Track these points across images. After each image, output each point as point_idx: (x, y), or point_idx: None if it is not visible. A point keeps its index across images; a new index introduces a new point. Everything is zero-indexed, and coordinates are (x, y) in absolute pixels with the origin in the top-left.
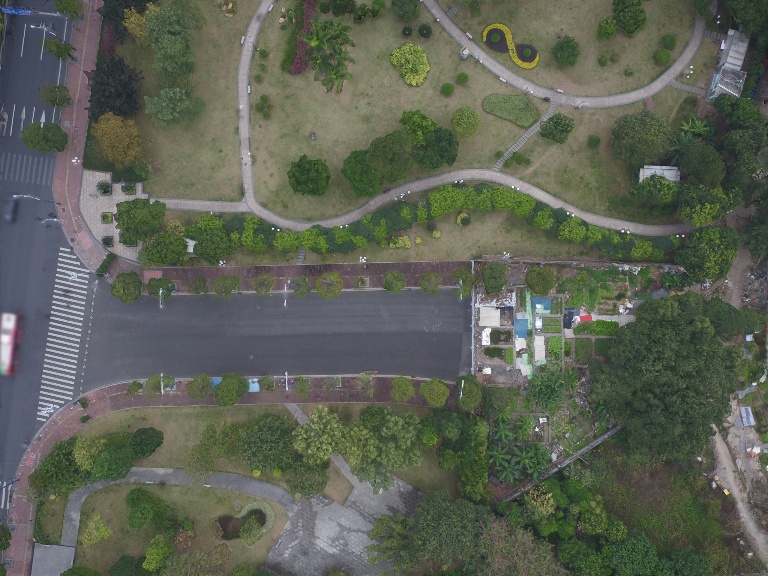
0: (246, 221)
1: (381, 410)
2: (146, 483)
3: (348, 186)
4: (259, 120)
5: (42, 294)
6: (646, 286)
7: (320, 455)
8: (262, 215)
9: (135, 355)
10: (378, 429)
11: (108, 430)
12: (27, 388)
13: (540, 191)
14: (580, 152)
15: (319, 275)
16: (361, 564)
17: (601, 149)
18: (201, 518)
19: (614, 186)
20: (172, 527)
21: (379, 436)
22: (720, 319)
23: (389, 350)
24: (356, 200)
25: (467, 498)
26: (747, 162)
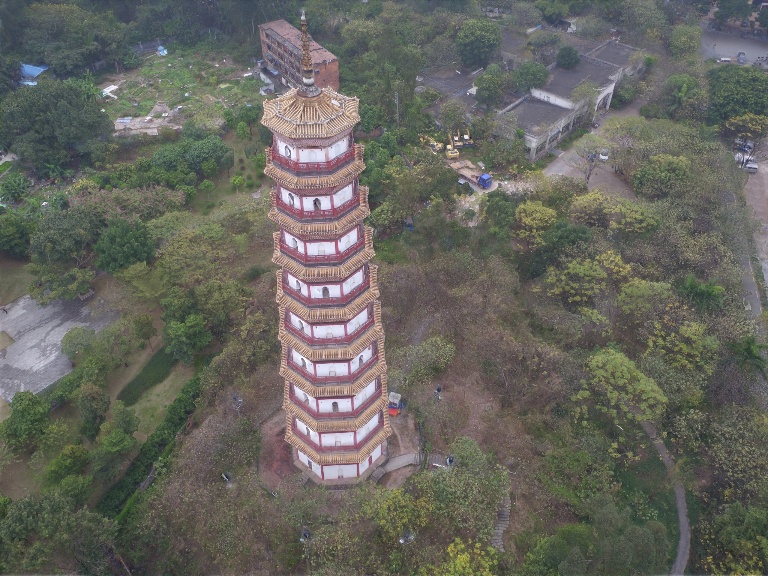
0: None
1: None
2: None
3: None
4: None
5: None
6: None
7: None
8: None
9: None
10: None
11: None
12: None
13: None
14: None
15: None
16: None
17: None
18: None
19: None
20: None
21: None
22: None
23: None
24: None
25: None
26: None
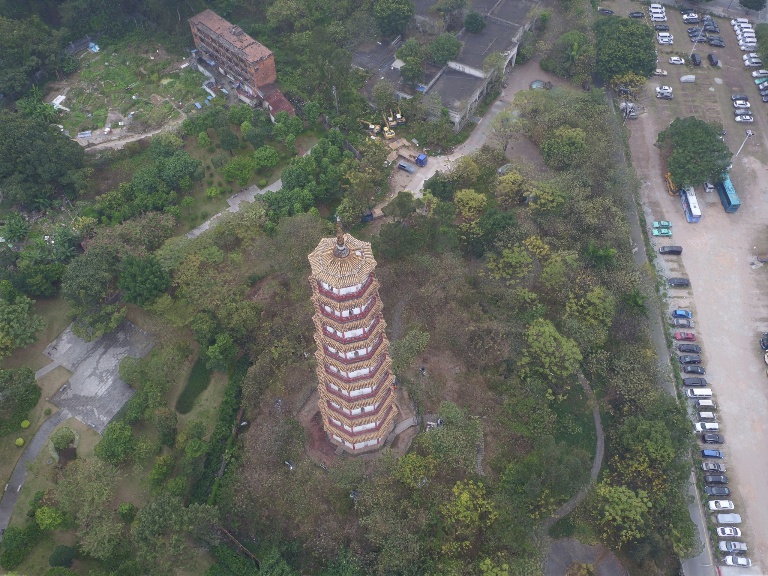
0: None
1: None
2: None
3: None
4: None
5: None
6: None
7: None
8: None
9: None
10: None
11: None
12: None
13: None
14: None
15: None
16: None
17: None
18: None
19: None
20: None
21: None
22: None
23: None
24: None
25: None
26: None
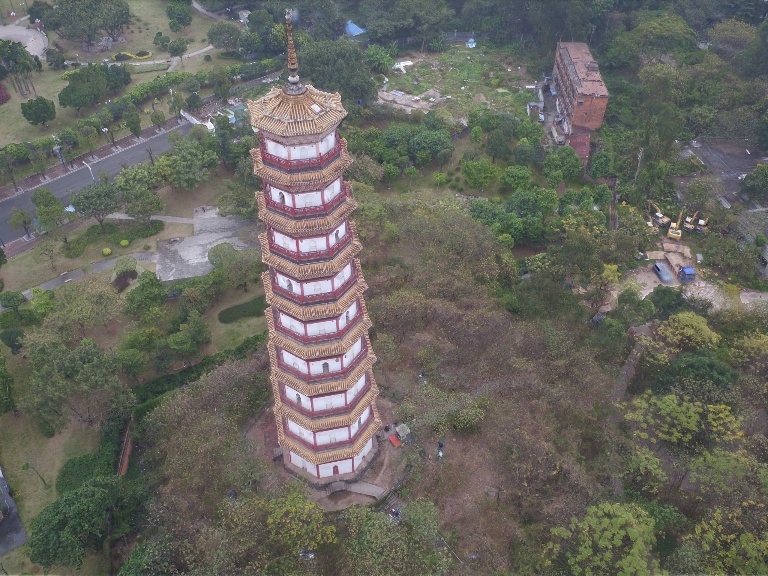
0: None
1: None
2: (8, 308)
3: (73, 123)
4: None
5: None
6: None
7: (140, 176)
8: None
9: None
10: None
11: None
12: None
13: None
14: (204, 64)
15: (82, 160)
16: None
17: (215, 60)
18: None
19: None
20: None
21: None
22: None
23: None
24: None
25: None
26: (277, 8)
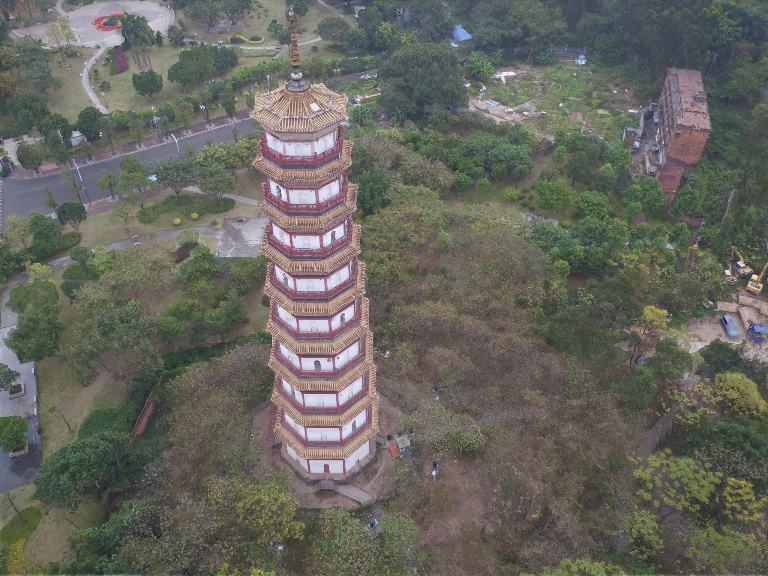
0: None
1: None
2: None
3: None
4: (104, 94)
5: None
6: None
7: (218, 154)
8: None
9: None
10: None
11: None
12: None
13: None
14: (310, 54)
15: (177, 133)
16: None
17: None
18: None
19: None
20: None
21: None
22: None
23: None
24: None
25: None
26: None
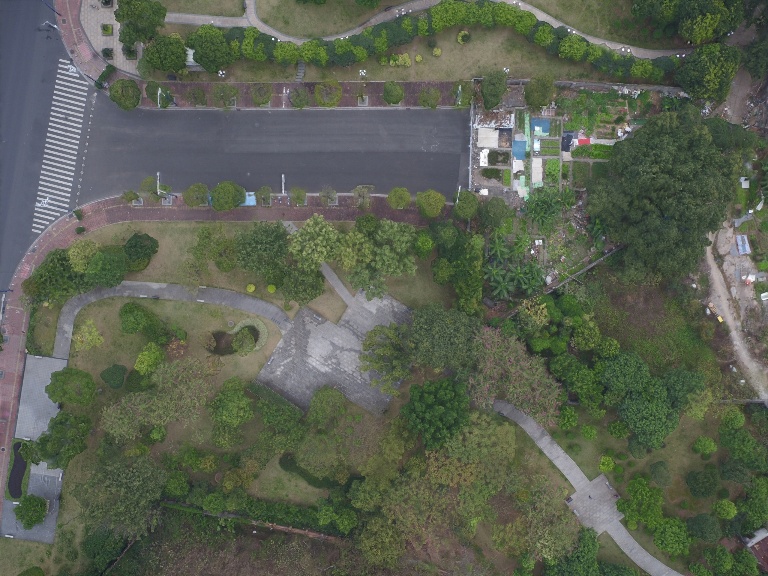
0: (246, 30)
1: (377, 220)
2: (140, 297)
3: (349, 3)
4: None
5: (40, 105)
6: (645, 110)
7: (315, 257)
8: (263, 31)
9: (132, 169)
10: (373, 237)
11: (103, 243)
12: (23, 199)
13: (542, 13)
14: None
15: None
16: (353, 383)
17: None
18: (194, 333)
19: (616, 9)
20: (165, 335)
21: (374, 243)
22: (718, 132)
23: (386, 169)
24: (357, 18)
25: (461, 311)
26: None
